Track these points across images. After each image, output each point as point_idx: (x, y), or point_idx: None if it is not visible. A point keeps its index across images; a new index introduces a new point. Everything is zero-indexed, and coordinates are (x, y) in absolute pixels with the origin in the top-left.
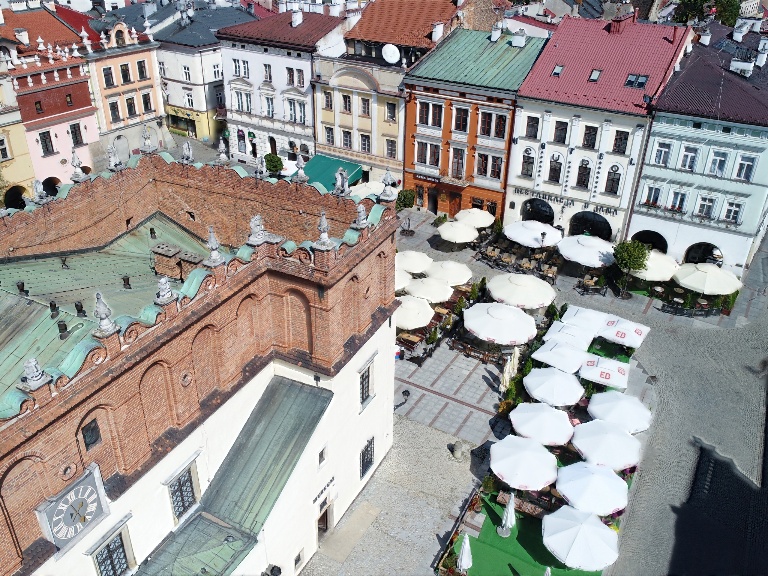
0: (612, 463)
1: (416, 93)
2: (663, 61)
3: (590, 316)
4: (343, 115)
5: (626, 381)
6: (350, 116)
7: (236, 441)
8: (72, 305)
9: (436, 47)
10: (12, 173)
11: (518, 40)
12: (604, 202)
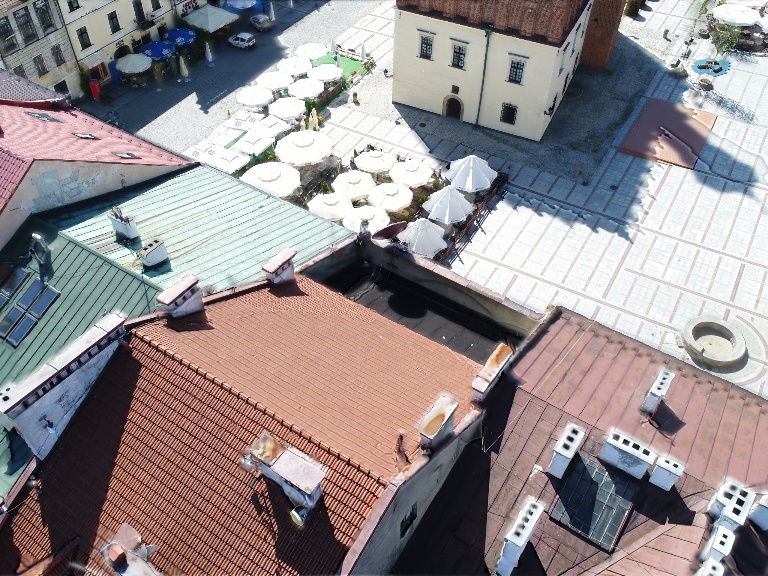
0: None
1: None
2: None
3: None
4: None
5: None
6: None
7: None
8: None
9: None
10: None
11: None
12: None
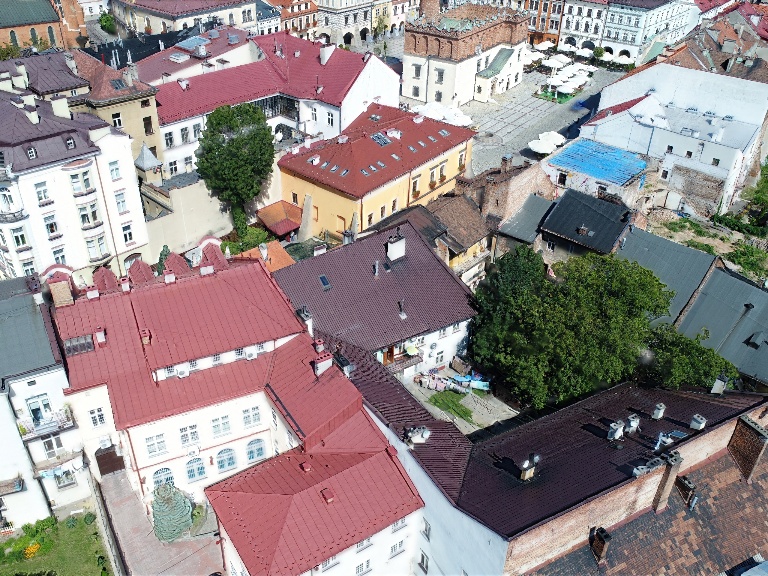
0: (577, 83)
1: None
2: None
3: (581, 64)
4: (500, 6)
5: (586, 75)
6: (503, 6)
7: (494, 58)
8: None
9: None
10: (386, 20)
11: None
12: (593, 37)
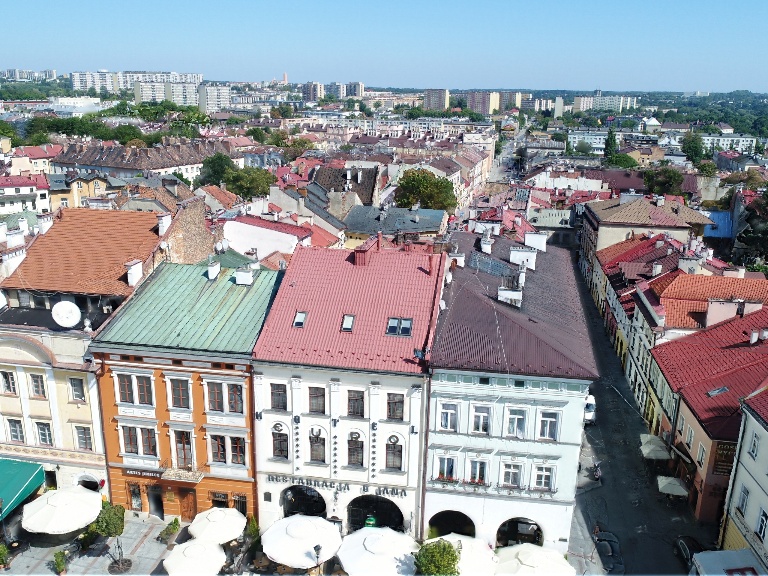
0: None
1: (110, 363)
2: (425, 298)
3: None
4: (5, 399)
5: None
6: (16, 399)
7: None
8: None
9: (134, 293)
10: None
11: (243, 277)
12: (387, 482)
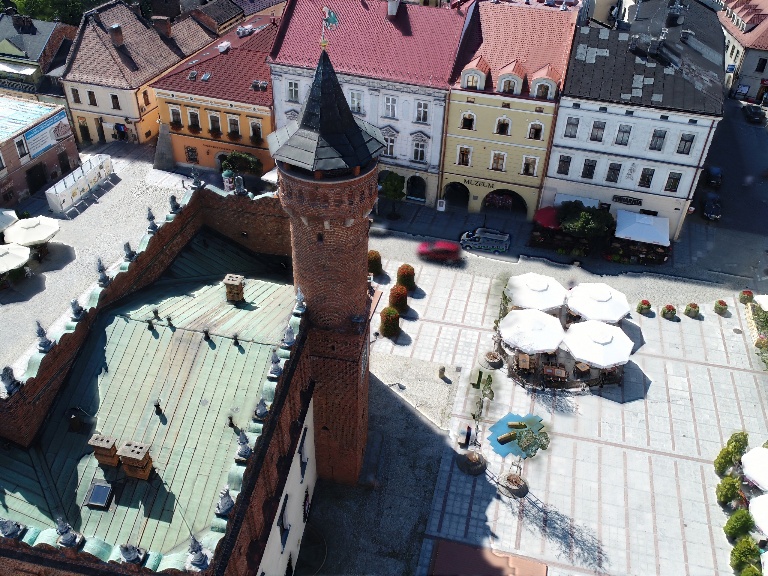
0: None
1: None
2: None
3: None
4: None
5: None
6: None
7: None
8: (169, 342)
9: None
10: None
11: None
12: None
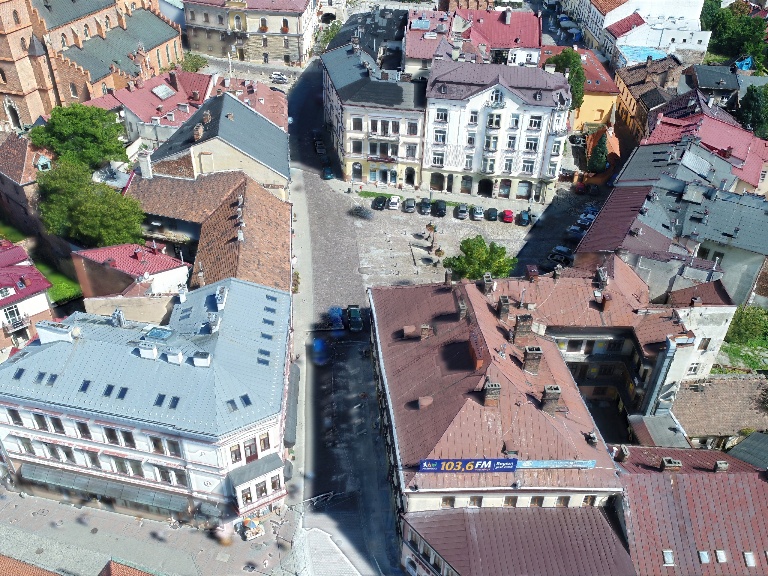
0: None
1: None
2: None
3: (501, 7)
4: None
5: None
6: None
7: None
8: None
9: None
10: None
11: None
12: None
